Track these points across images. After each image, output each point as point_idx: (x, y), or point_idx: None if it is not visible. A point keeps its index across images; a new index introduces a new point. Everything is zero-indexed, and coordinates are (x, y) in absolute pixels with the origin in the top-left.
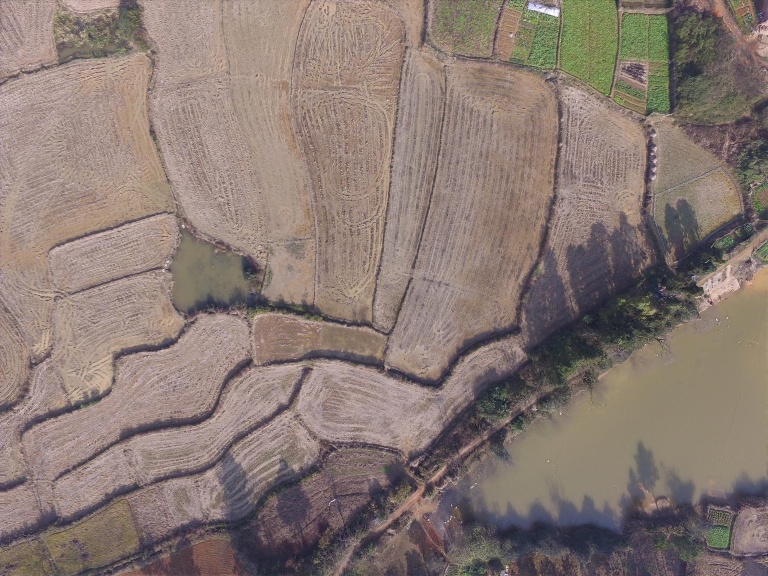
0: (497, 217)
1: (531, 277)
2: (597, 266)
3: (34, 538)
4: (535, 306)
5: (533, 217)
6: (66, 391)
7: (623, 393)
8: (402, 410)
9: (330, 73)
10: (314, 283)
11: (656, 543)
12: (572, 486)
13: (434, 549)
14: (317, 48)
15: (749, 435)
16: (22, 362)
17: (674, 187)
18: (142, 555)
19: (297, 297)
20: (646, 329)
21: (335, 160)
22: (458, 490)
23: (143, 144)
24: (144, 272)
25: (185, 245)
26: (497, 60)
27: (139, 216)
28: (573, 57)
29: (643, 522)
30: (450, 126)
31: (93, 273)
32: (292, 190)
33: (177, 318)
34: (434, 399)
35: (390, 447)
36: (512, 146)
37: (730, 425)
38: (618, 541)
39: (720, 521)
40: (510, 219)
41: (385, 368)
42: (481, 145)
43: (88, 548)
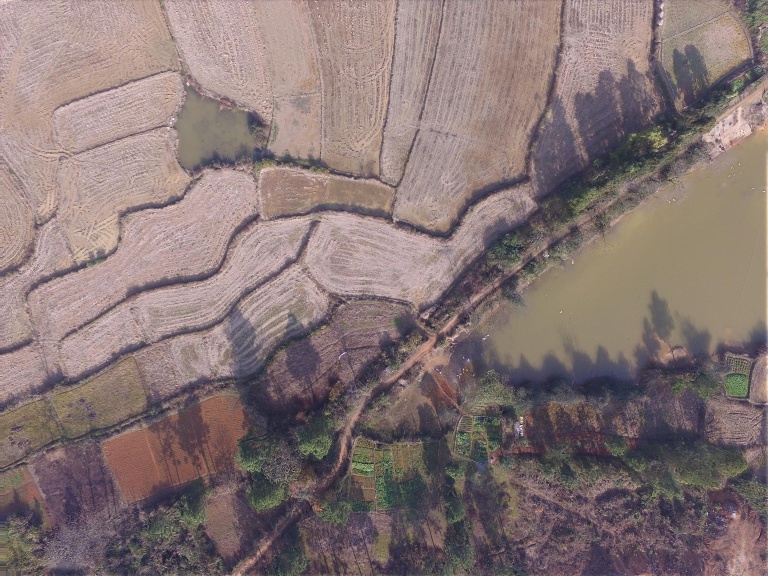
0: (504, 67)
1: (539, 125)
2: (606, 114)
3: (40, 399)
4: (544, 155)
5: (540, 67)
6: (72, 251)
7: (636, 241)
8: (411, 262)
9: None
10: (320, 137)
11: (674, 385)
12: (586, 337)
13: (447, 402)
14: None
15: (765, 282)
16: (27, 224)
17: (682, 32)
18: (150, 413)
19: (303, 152)
20: (658, 156)
21: (339, 14)
22: (470, 342)
23: (147, 3)
24: (149, 130)
25: (190, 103)
26: None
27: (143, 75)
28: None
29: (660, 371)
30: None
31: (98, 133)
32: (297, 45)
33: (183, 176)
34: (444, 250)
35: (400, 299)
36: None
37: (746, 272)
38: (635, 388)
39: (738, 369)
40: (517, 69)
41: (393, 220)
42: None
43: (95, 407)
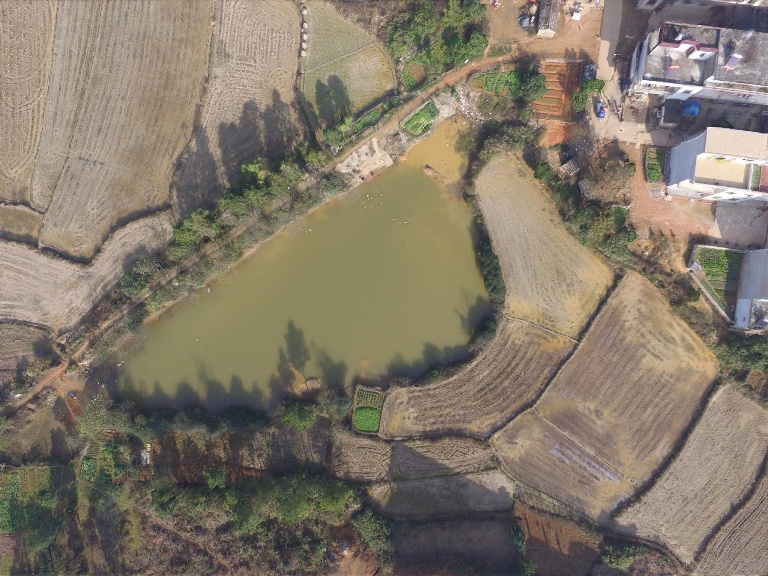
0: (153, 97)
1: (182, 154)
2: (249, 143)
3: None
4: (187, 184)
5: (188, 96)
6: None
7: (272, 270)
8: (53, 287)
9: None
10: None
11: None
12: (221, 366)
13: (78, 427)
14: None
15: (403, 315)
16: None
17: (325, 63)
18: None
19: None
20: (249, 188)
21: None
22: (105, 368)
23: None
24: None
25: None
26: None
27: None
28: None
29: (288, 402)
30: (109, 9)
31: None
32: None
33: None
34: (84, 276)
35: (40, 324)
36: (169, 27)
37: (383, 304)
38: (257, 419)
39: (369, 402)
40: (165, 99)
41: (39, 246)
42: (139, 27)
43: None
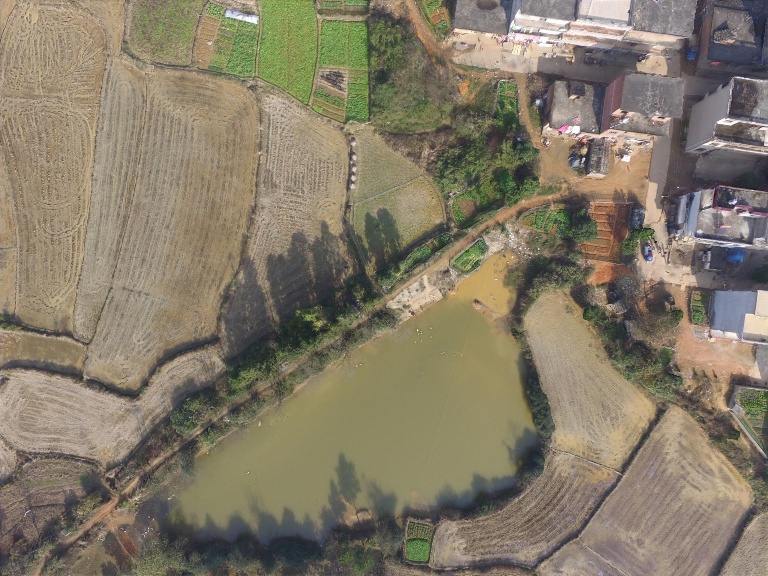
0: (198, 226)
1: (230, 287)
2: (298, 276)
3: None
4: (235, 316)
5: (234, 226)
6: None
7: (322, 404)
8: (99, 421)
9: (32, 81)
10: (15, 292)
11: (339, 557)
12: (272, 498)
13: (130, 561)
14: (19, 56)
15: (452, 447)
16: None
17: (374, 196)
18: None
19: None
20: (307, 341)
21: (36, 169)
22: (155, 501)
23: None
24: None
25: None
26: (195, 68)
27: None
28: (271, 65)
29: (340, 535)
30: (150, 134)
31: None
32: None
33: None
34: (132, 410)
35: (87, 458)
36: (213, 155)
37: (433, 437)
38: (311, 554)
39: (420, 534)
40: (211, 228)
41: (84, 378)
42: (182, 154)
43: None
